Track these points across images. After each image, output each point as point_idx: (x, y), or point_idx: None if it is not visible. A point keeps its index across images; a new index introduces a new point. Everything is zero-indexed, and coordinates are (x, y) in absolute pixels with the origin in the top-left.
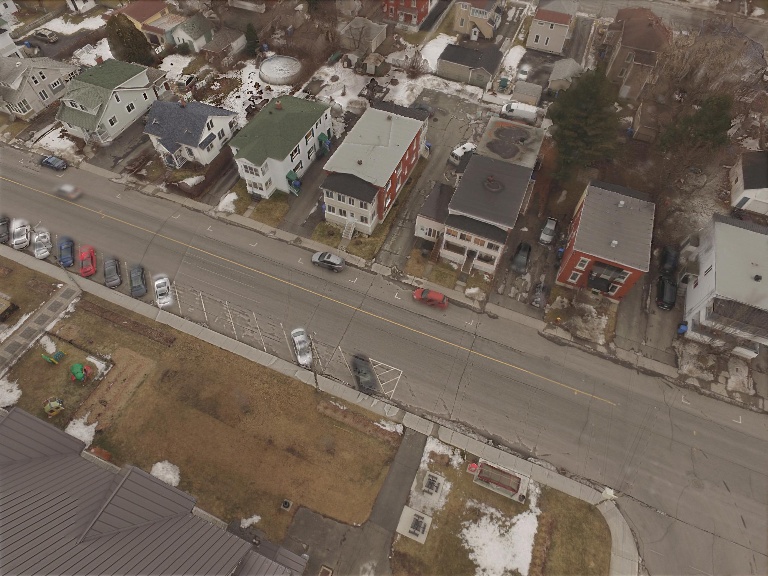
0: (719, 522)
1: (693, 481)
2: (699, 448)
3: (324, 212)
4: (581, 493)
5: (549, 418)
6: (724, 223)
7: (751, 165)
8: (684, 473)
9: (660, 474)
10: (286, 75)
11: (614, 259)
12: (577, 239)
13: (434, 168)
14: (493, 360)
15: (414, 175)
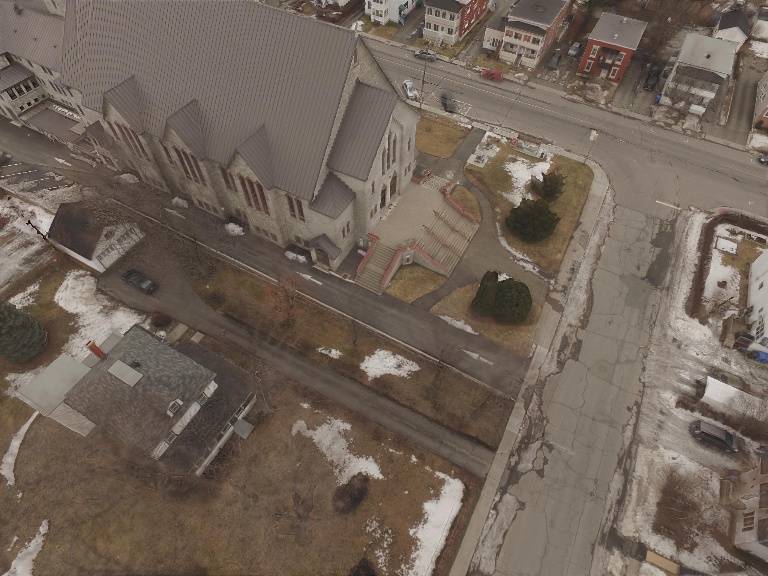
0: (662, 176)
1: (650, 160)
2: (657, 148)
3: (422, 33)
4: (578, 159)
5: (563, 130)
6: (693, 33)
7: (726, 18)
8: (645, 157)
9: (629, 156)
10: None
11: (614, 43)
12: (592, 34)
13: (497, 17)
14: (530, 105)
15: (483, 19)
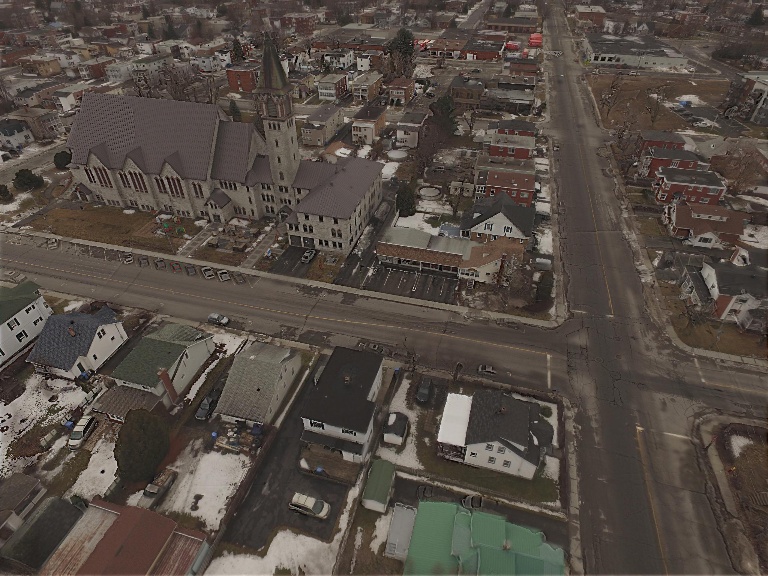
0: None
1: None
2: None
3: None
4: None
5: None
6: None
7: None
8: None
9: None
10: None
11: None
12: None
13: None
14: None
15: None
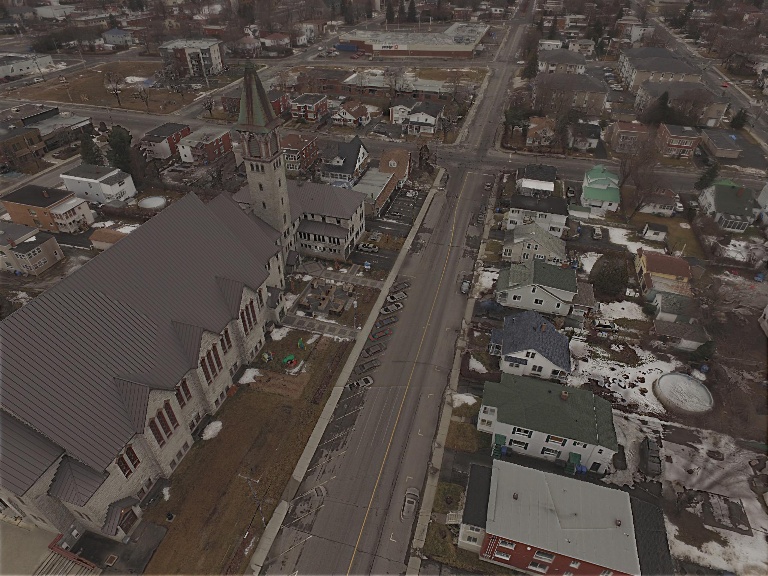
0: None
1: None
2: None
3: None
4: None
5: None
6: None
7: None
8: None
9: None
10: (675, 400)
11: None
12: None
13: None
14: None
15: None
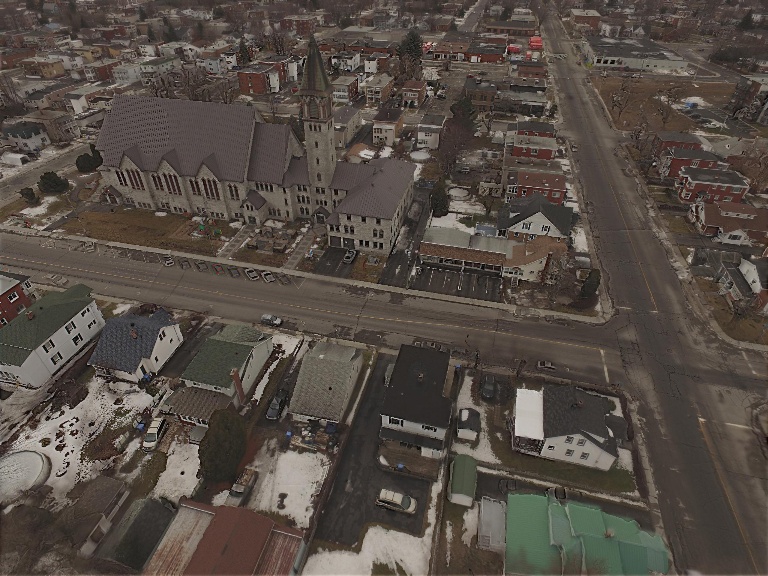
0: None
1: None
2: None
3: None
4: None
5: None
6: None
7: None
8: None
9: None
10: (8, 461)
11: None
12: None
13: None
14: None
15: None
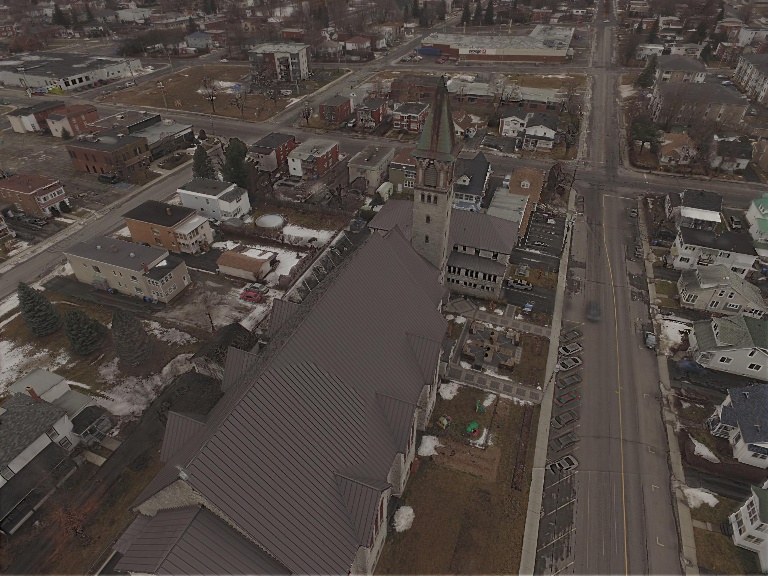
0: None
1: None
2: None
3: None
4: None
5: None
6: None
7: None
8: None
9: None
10: None
11: None
12: None
13: None
14: None
15: None
